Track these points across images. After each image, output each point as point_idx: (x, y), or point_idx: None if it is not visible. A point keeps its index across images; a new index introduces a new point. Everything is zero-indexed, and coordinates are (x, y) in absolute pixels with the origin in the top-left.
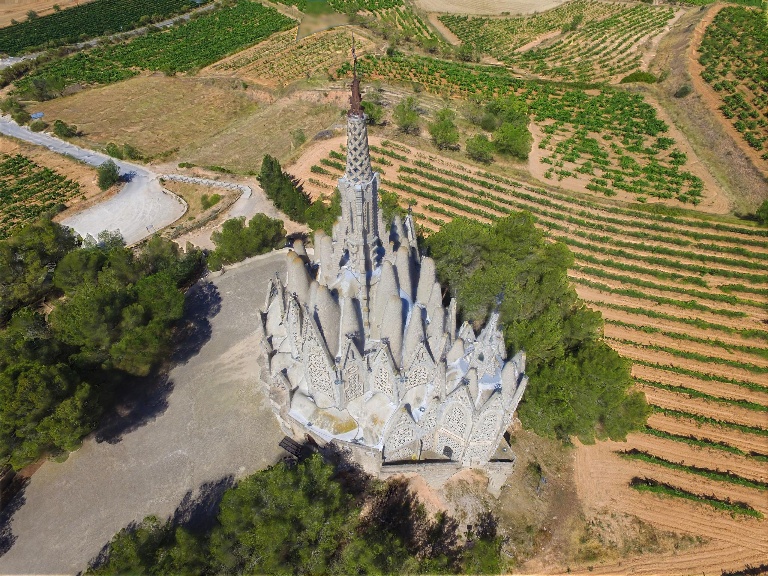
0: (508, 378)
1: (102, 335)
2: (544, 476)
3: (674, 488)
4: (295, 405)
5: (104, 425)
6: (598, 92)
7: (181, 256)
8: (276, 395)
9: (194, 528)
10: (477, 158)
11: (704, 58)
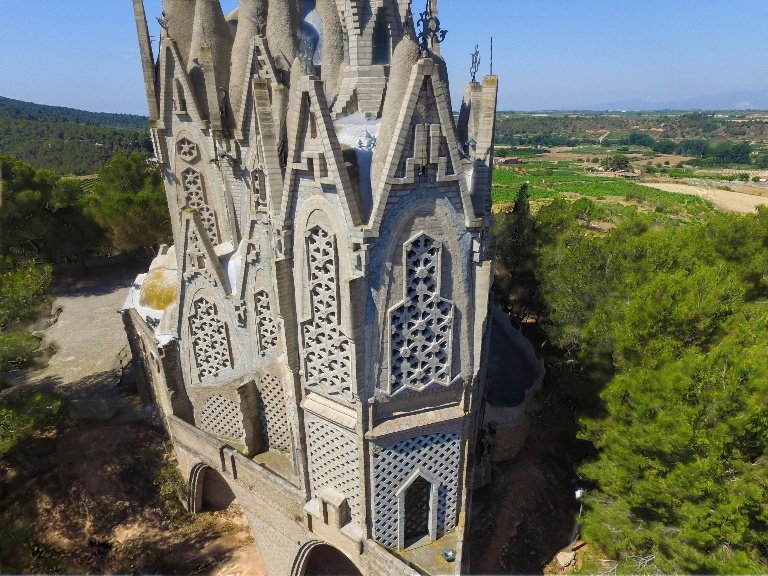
0: (391, 97)
1: (114, 192)
2: None
3: None
4: (152, 263)
5: (58, 286)
6: None
7: None
8: None
9: None
10: None
11: None
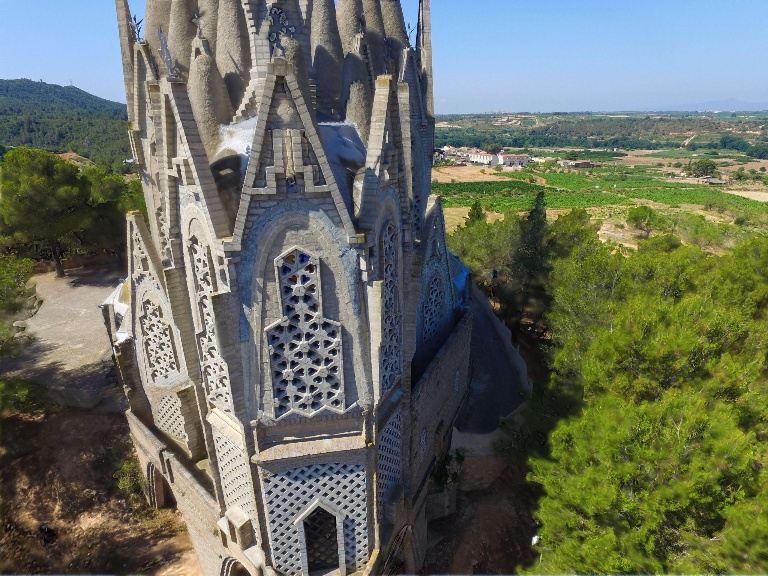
0: None
1: None
2: None
3: None
4: None
5: (94, 276)
6: None
7: None
8: None
9: None
10: None
11: None
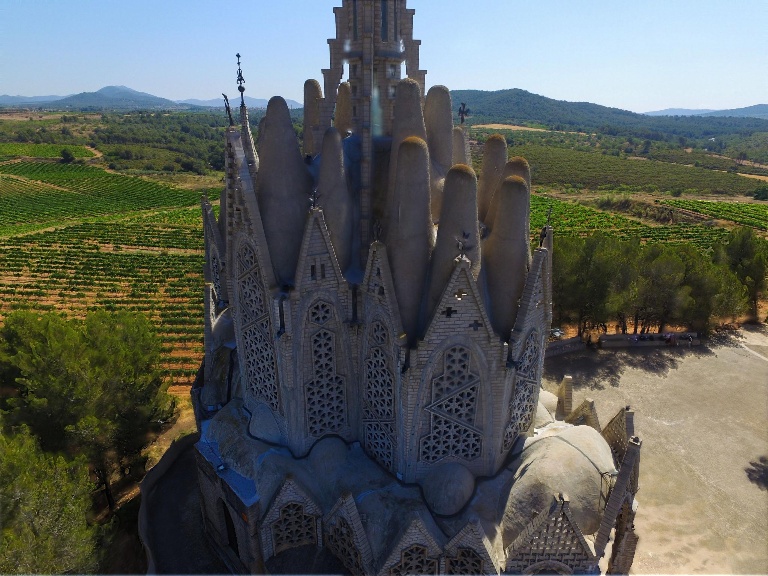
0: None
1: None
2: None
3: None
4: None
5: None
6: None
7: None
8: None
9: (588, 366)
10: None
11: None
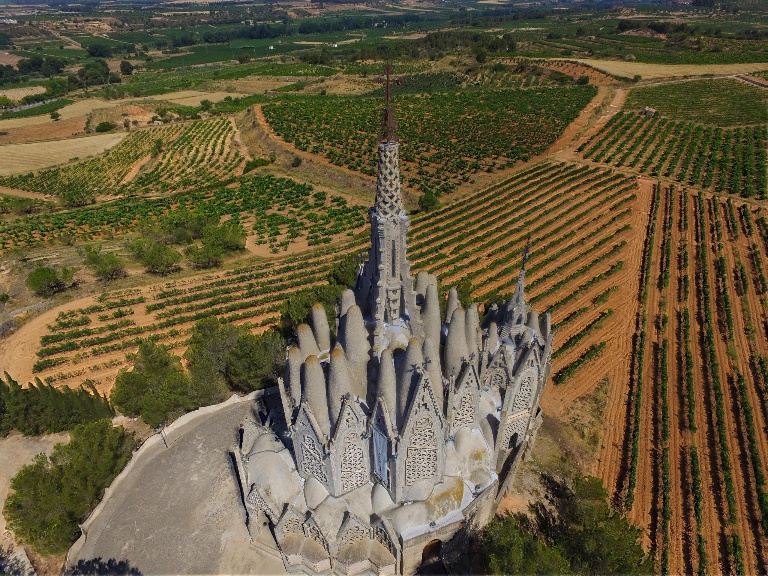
0: None
1: None
2: None
3: (569, 366)
4: (403, 524)
5: None
6: (237, 184)
7: None
8: (351, 555)
9: None
10: (207, 266)
11: (287, 138)
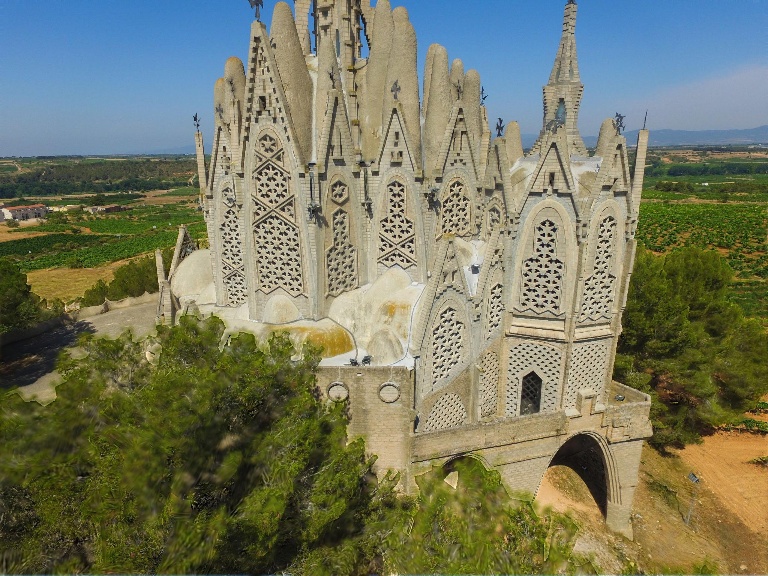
0: None
1: None
2: (680, 500)
3: None
4: None
5: None
6: None
7: (41, 309)
8: None
9: None
10: None
11: None
